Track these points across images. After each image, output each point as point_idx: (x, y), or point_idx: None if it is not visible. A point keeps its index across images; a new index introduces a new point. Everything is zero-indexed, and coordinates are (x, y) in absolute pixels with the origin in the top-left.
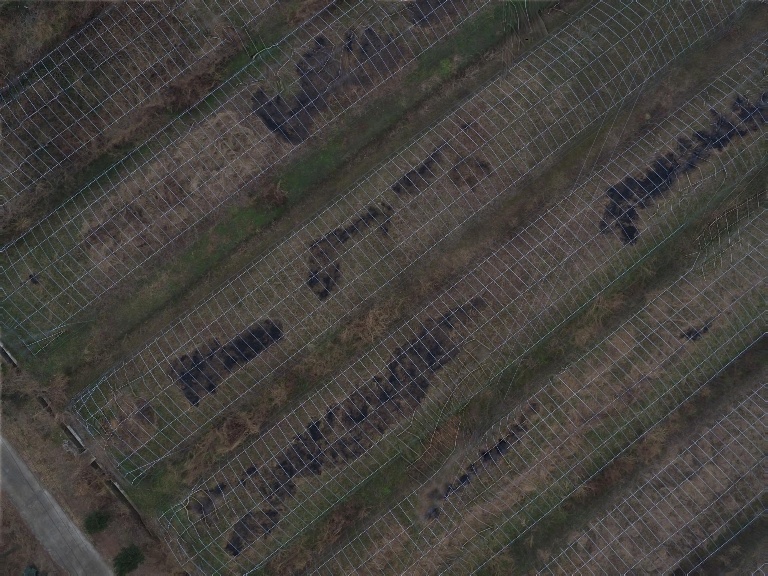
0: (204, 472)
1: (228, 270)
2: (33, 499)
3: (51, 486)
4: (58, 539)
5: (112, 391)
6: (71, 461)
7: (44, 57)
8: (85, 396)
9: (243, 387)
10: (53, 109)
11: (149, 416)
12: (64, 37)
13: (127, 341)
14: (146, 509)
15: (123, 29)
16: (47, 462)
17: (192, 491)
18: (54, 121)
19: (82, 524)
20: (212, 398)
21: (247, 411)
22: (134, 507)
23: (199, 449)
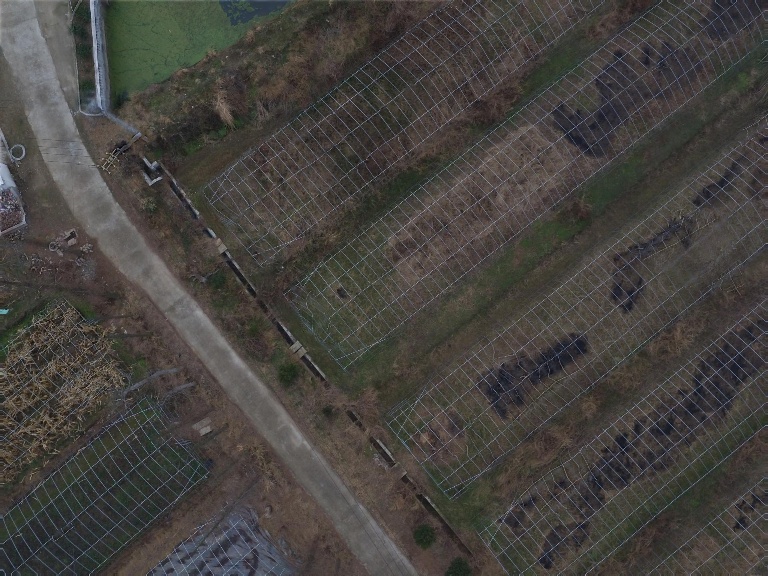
0: (518, 486)
1: (692, 289)
2: (348, 513)
3: (366, 500)
4: (374, 554)
5: (439, 406)
6: (383, 475)
7: (357, 71)
8: (407, 410)
9: (562, 401)
10: (375, 123)
11: (478, 431)
12: (371, 51)
13: (436, 355)
14: (460, 523)
15: (441, 44)
16: (361, 476)
17: (512, 505)
18: (375, 135)
19: (398, 538)
20: (531, 412)
21: (565, 425)
22: (446, 521)
23: (516, 463)
